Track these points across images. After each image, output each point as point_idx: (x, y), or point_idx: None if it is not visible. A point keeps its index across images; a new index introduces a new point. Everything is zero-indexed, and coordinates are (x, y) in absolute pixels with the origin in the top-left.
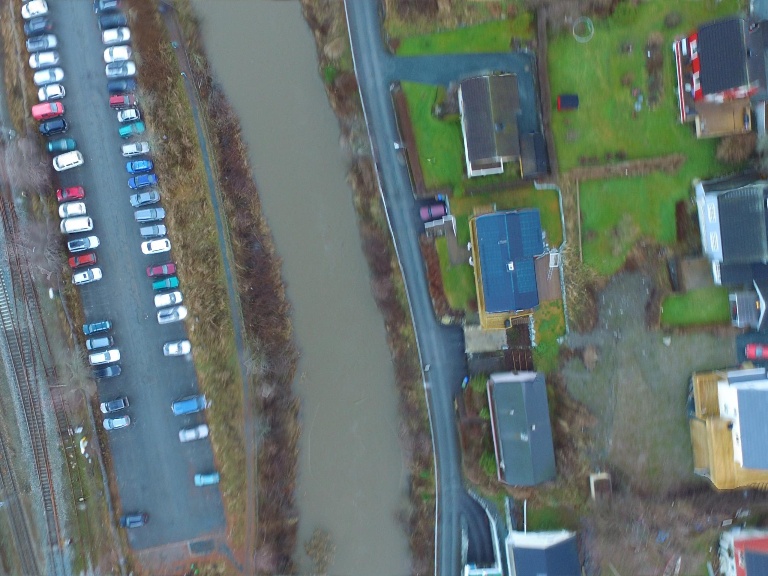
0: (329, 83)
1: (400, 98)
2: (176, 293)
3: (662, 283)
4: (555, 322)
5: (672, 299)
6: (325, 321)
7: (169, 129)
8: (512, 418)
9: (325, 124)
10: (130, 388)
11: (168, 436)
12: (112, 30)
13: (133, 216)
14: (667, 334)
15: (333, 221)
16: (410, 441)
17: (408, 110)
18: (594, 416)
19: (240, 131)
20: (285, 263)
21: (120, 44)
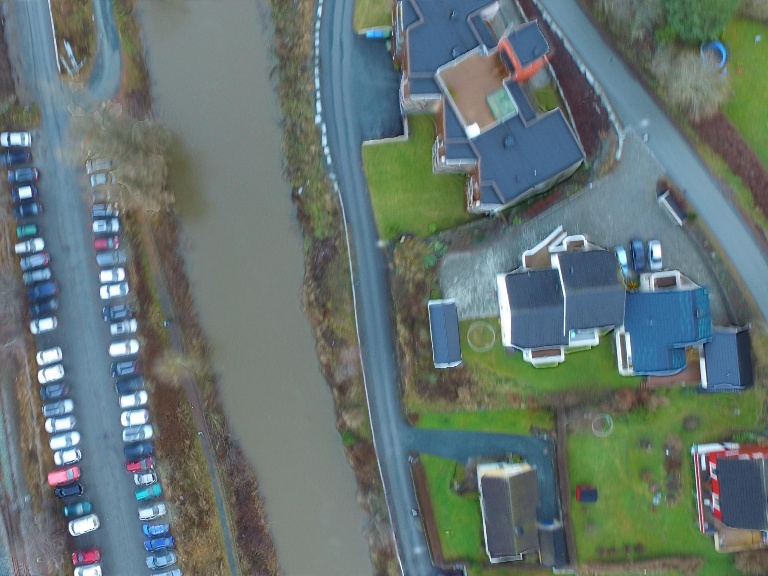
0: (347, 446)
1: (419, 473)
2: None
3: None
4: None
5: None
6: None
7: (186, 491)
8: None
9: (342, 477)
10: None
11: None
12: (129, 396)
13: None
14: None
15: (350, 572)
16: None
17: (427, 485)
18: None
19: (257, 488)
20: None
21: (137, 408)
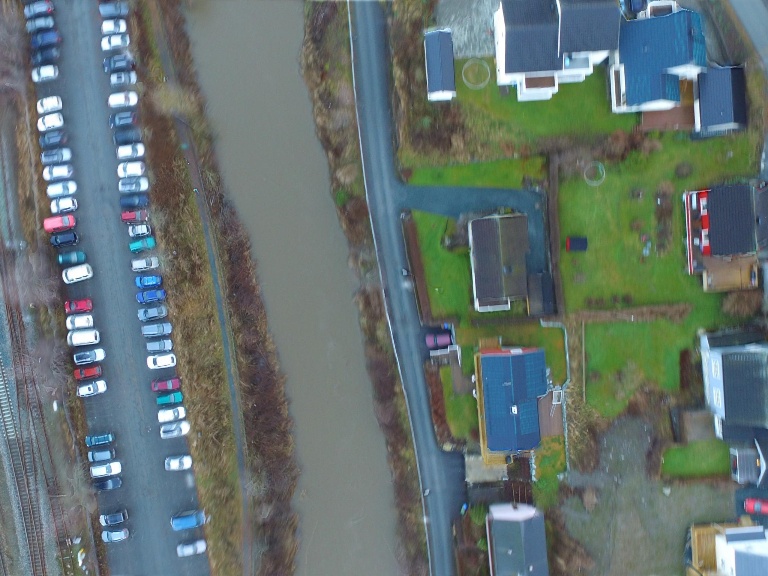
0: (340, 206)
1: (410, 228)
2: (180, 408)
3: (664, 432)
4: (556, 458)
5: (673, 450)
6: (327, 439)
7: (179, 245)
8: (510, 558)
9: (334, 243)
10: (130, 500)
11: (166, 549)
12: (127, 146)
13: (140, 330)
14: (667, 484)
15: (339, 339)
16: (407, 566)
17: (418, 240)
18: (591, 559)
19: (250, 248)
20: (289, 380)
21: (134, 160)
